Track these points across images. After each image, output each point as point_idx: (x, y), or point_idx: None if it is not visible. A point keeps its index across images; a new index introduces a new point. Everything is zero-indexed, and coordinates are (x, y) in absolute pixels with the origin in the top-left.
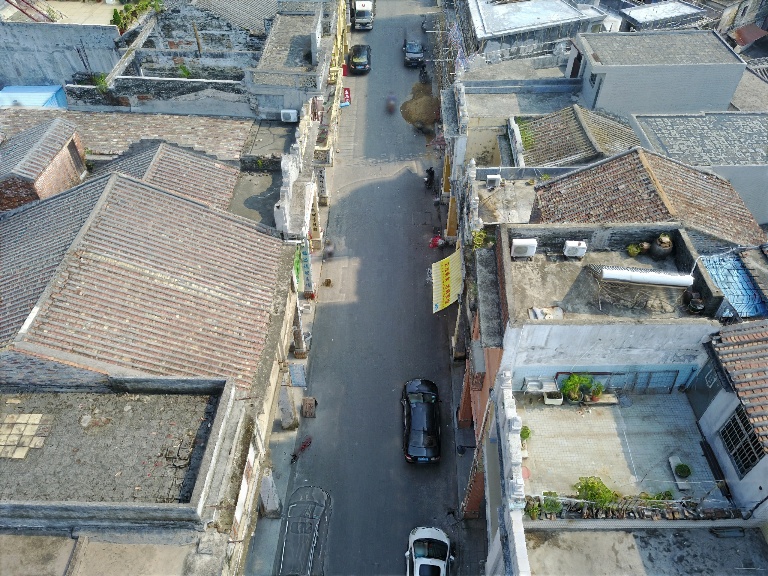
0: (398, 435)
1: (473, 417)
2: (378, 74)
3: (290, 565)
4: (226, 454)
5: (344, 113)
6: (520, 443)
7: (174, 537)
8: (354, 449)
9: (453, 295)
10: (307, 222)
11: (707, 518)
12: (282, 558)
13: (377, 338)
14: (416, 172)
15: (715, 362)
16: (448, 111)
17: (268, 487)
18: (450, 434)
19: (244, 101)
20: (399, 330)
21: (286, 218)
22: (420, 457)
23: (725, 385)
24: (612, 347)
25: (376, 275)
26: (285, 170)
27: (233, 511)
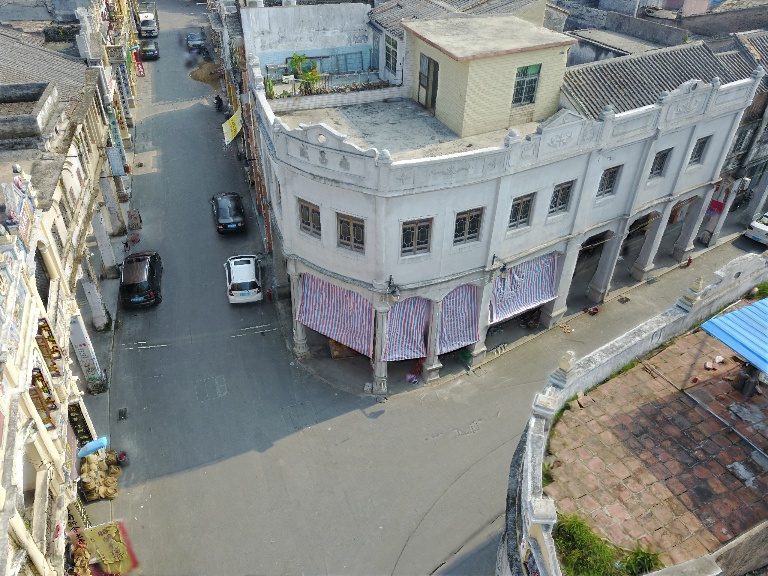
0: (212, 226)
1: (255, 158)
2: (167, 59)
3: (130, 279)
4: (56, 117)
5: (140, 81)
6: (260, 72)
7: (22, 154)
8: (177, 238)
9: (238, 128)
10: (111, 96)
11: (376, 87)
12: (122, 275)
13: (187, 185)
14: (208, 104)
15: (373, 26)
16: (214, 20)
17: (102, 230)
18: (254, 220)
19: (41, 5)
20: (205, 179)
21: (87, 46)
22: (229, 224)
23: (377, 30)
24: (313, 29)
25: (182, 156)
26: (81, 16)
27: (67, 149)
